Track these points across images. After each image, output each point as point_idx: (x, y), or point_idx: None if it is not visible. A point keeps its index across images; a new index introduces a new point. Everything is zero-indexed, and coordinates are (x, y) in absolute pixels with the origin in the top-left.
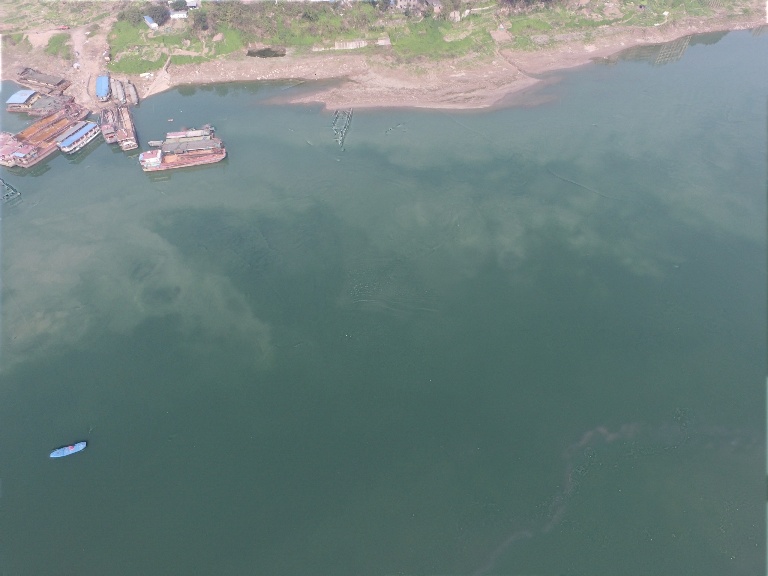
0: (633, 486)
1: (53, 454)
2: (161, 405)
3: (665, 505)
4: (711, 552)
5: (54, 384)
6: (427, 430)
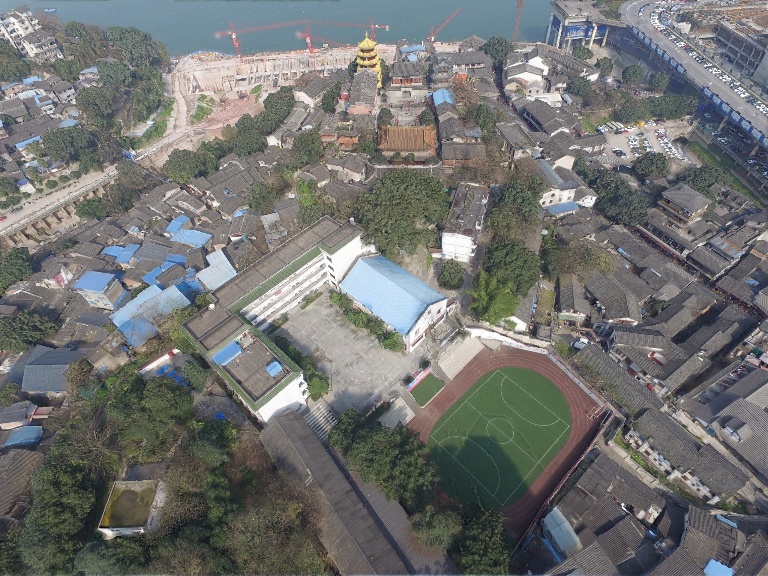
0: (233, 5)
1: (45, 10)
2: (83, 6)
3: (241, 8)
4: (246, 11)
5: (45, 2)
6: (173, 3)
